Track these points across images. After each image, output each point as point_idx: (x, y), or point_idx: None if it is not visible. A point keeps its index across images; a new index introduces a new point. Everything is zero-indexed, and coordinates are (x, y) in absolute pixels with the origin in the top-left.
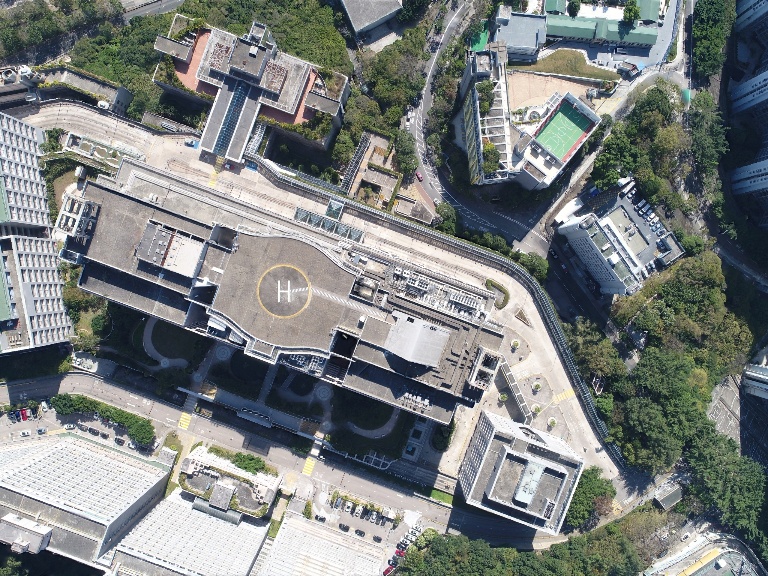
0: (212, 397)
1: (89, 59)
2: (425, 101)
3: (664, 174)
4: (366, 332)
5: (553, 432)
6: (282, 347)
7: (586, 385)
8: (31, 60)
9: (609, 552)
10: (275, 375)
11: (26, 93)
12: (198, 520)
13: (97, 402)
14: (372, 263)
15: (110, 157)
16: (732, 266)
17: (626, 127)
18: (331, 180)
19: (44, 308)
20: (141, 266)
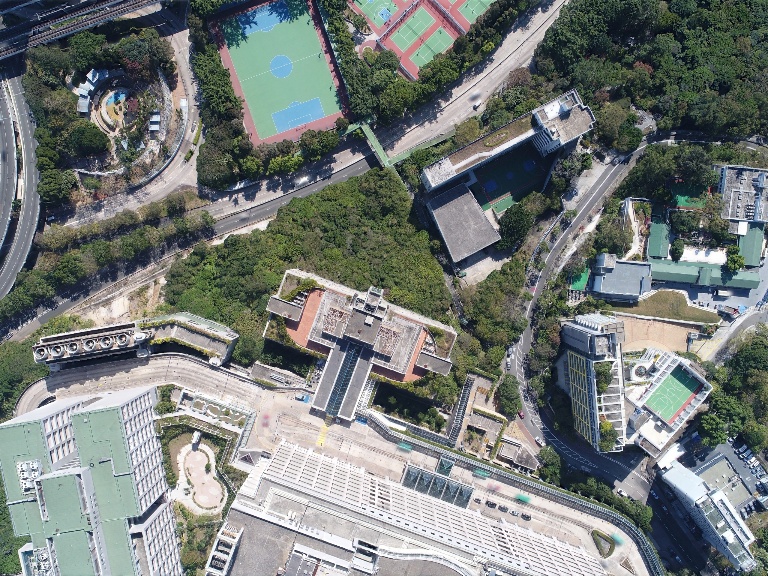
0: None
1: (187, 286)
2: (525, 336)
3: (766, 422)
4: None
5: None
6: None
7: None
8: (121, 270)
9: None
10: None
11: (137, 350)
12: None
13: None
14: (506, 575)
15: (223, 415)
16: None
17: (729, 376)
18: (436, 423)
19: None
20: None
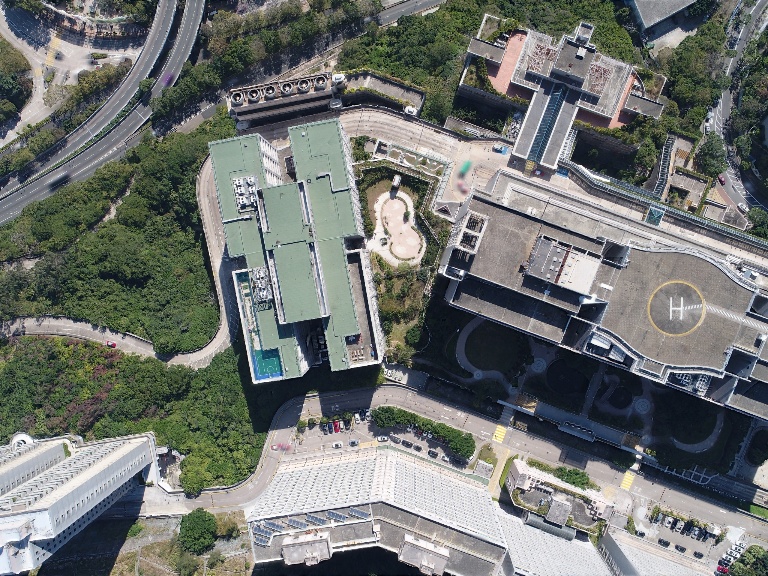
0: (532, 410)
1: (362, 61)
2: (724, 100)
3: None
4: (765, 351)
5: None
6: (673, 366)
7: None
8: (285, 62)
9: None
10: (598, 388)
11: (331, 99)
12: (538, 536)
13: (416, 415)
14: (761, 278)
15: (420, 165)
16: None
17: None
18: (634, 185)
19: None
20: (526, 283)
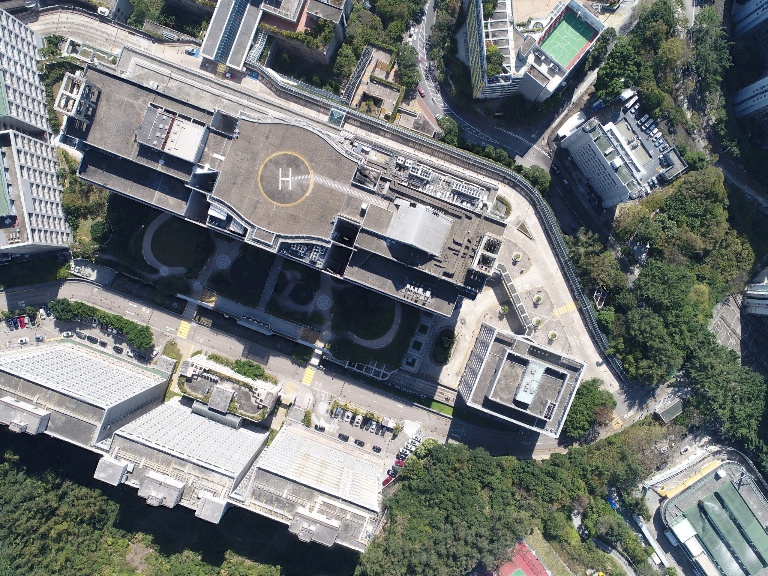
0: (212, 304)
1: None
2: (428, 17)
3: (667, 88)
4: (368, 220)
5: (554, 345)
6: (283, 235)
7: (587, 298)
8: None
9: (609, 460)
10: (275, 282)
11: None
12: (197, 422)
13: (96, 308)
14: (374, 153)
15: None
16: (734, 186)
17: (630, 40)
18: (333, 93)
19: (43, 209)
20: (141, 152)
